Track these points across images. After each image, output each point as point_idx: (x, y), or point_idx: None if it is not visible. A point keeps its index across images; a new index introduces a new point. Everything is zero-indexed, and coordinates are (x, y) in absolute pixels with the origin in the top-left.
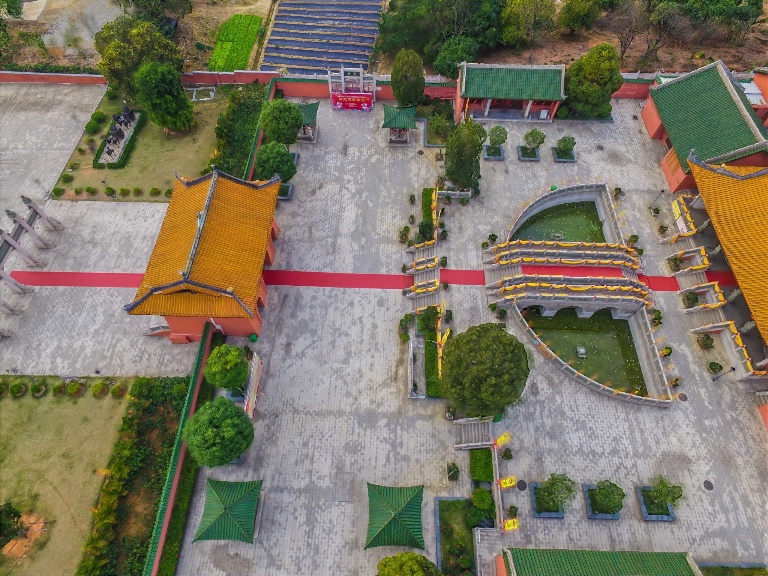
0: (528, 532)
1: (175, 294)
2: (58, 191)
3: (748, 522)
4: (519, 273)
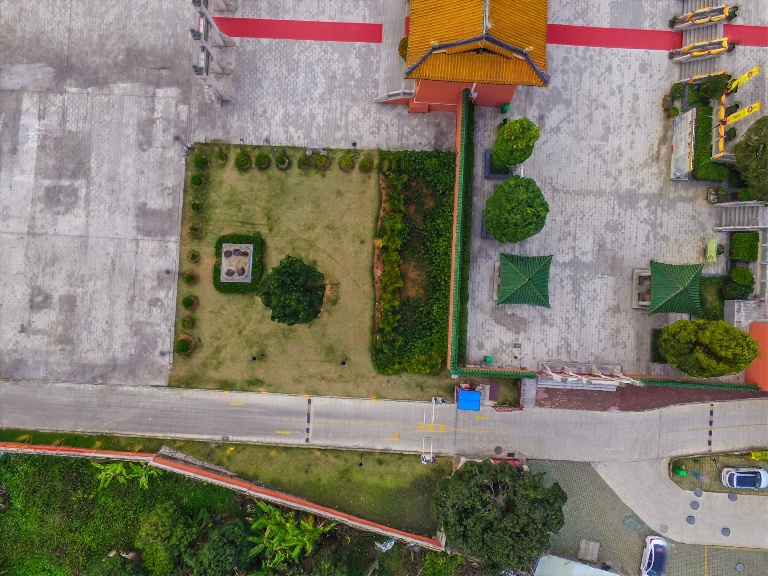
0: None
1: (457, 54)
2: None
3: None
4: None
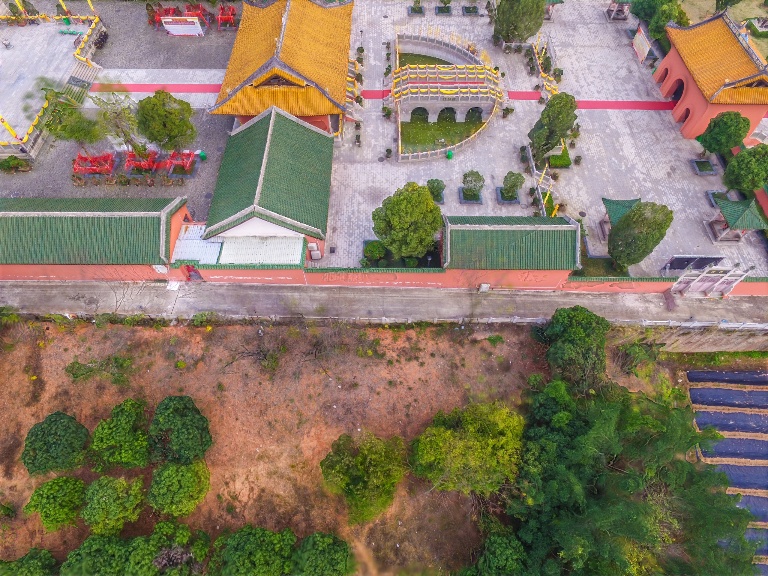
0: (479, 4)
1: None
2: None
3: (372, 8)
4: None
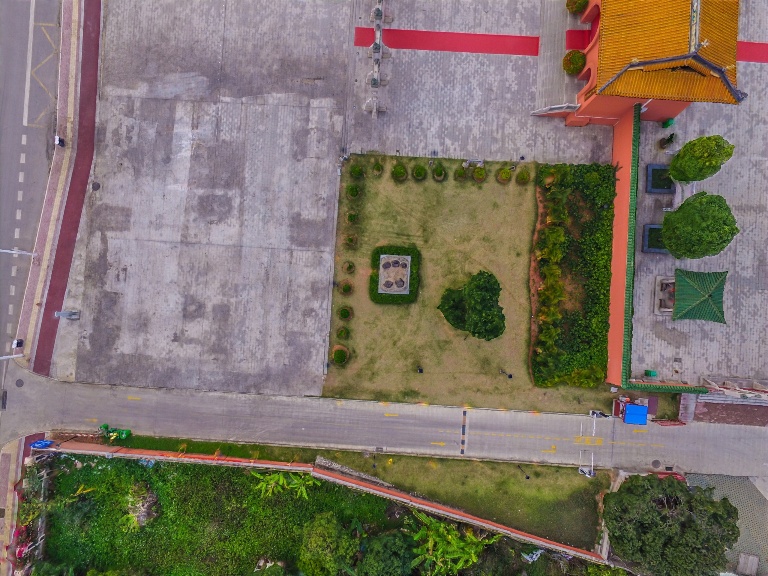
0: None
1: (652, 71)
2: None
3: None
4: None
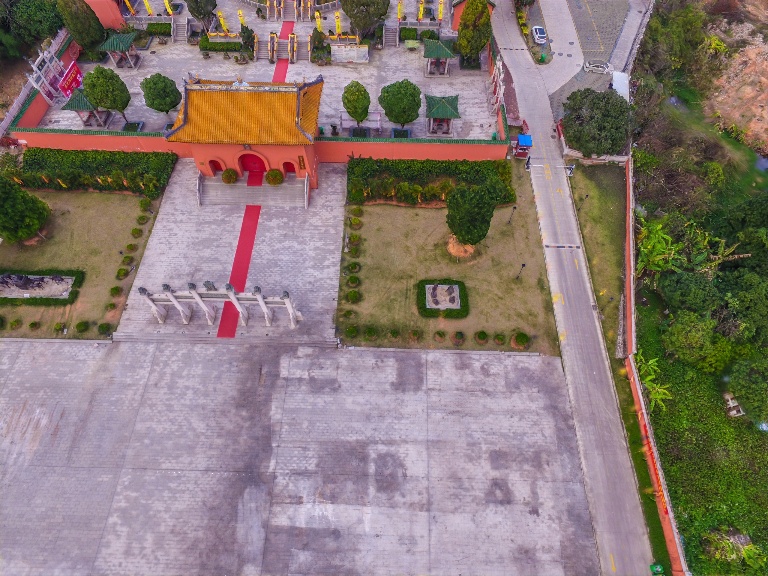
0: None
1: None
2: (104, 325)
3: None
4: (291, 1)
